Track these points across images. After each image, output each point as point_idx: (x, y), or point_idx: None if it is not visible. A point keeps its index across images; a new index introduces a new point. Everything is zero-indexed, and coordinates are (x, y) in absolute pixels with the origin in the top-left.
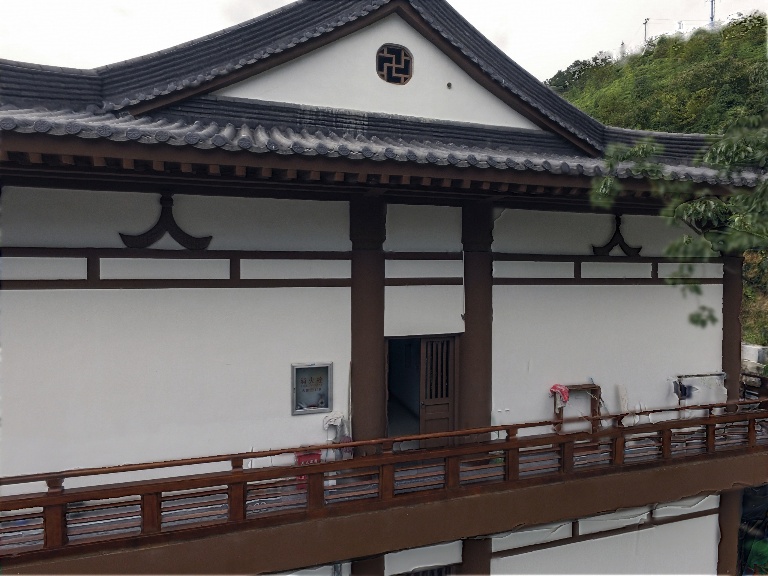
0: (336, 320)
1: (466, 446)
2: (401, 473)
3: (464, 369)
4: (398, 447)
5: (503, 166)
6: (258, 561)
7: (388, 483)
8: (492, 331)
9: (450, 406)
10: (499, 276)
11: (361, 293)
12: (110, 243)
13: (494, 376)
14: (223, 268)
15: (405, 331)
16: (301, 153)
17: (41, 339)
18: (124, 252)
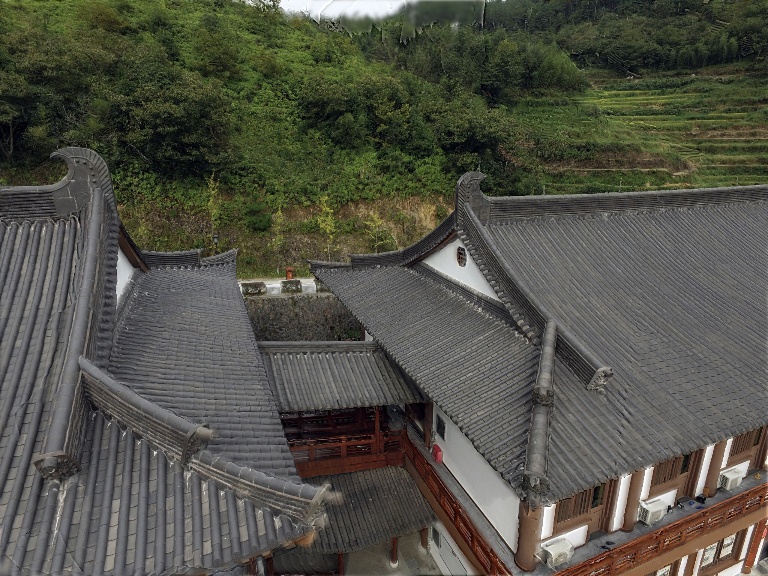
0: None
1: None
2: None
3: None
4: None
5: None
6: None
7: None
8: None
9: None
10: None
11: None
12: None
13: None
14: None
15: None
16: None
17: None
18: None
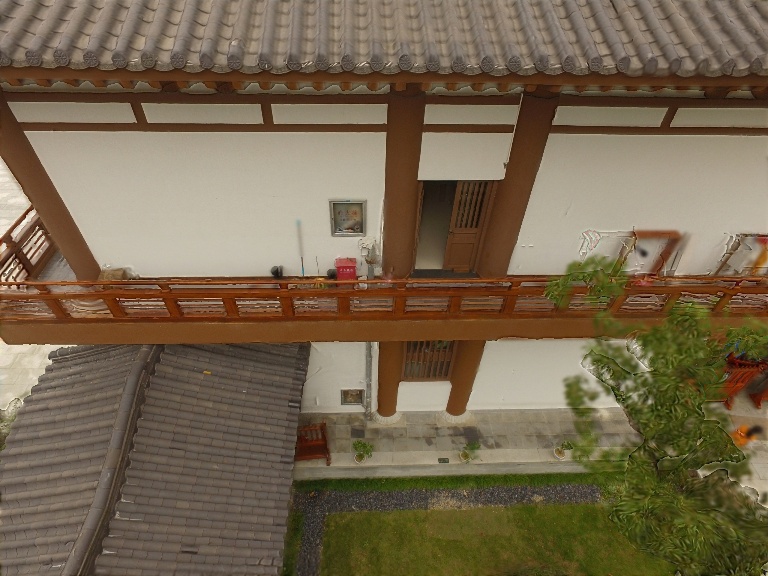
0: (370, 164)
1: (470, 290)
2: (412, 300)
3: (496, 211)
4: (411, 285)
5: (557, 70)
6: (305, 336)
7: (400, 306)
8: (535, 179)
9: (477, 235)
10: (560, 123)
11: (396, 141)
12: (145, 87)
13: (526, 218)
14: (256, 112)
15: (440, 176)
16: (298, 70)
17: (120, 171)
18: (160, 97)
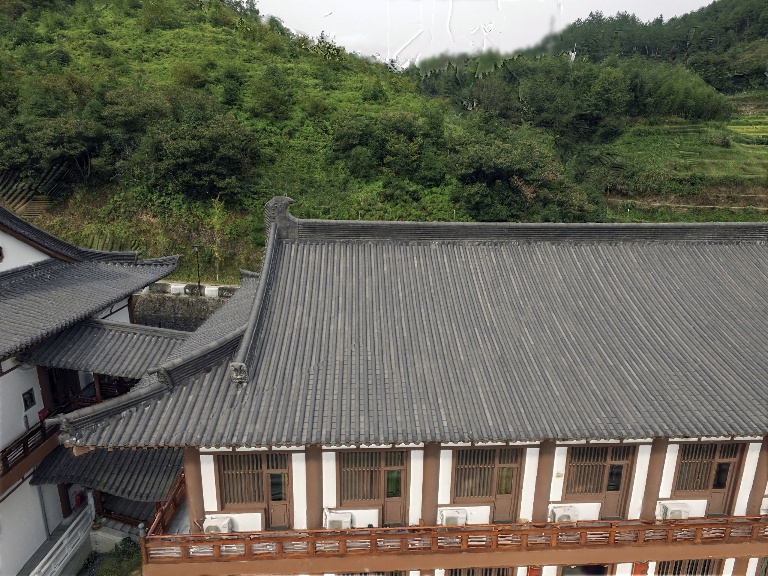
0: None
1: None
2: None
3: None
4: None
5: None
6: None
7: None
8: None
9: None
10: None
11: None
12: None
13: None
14: None
15: None
16: None
17: None
18: None
